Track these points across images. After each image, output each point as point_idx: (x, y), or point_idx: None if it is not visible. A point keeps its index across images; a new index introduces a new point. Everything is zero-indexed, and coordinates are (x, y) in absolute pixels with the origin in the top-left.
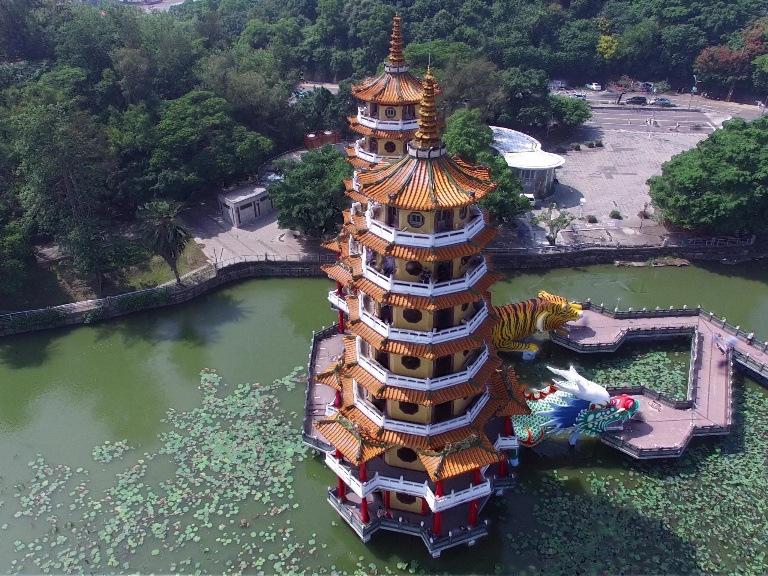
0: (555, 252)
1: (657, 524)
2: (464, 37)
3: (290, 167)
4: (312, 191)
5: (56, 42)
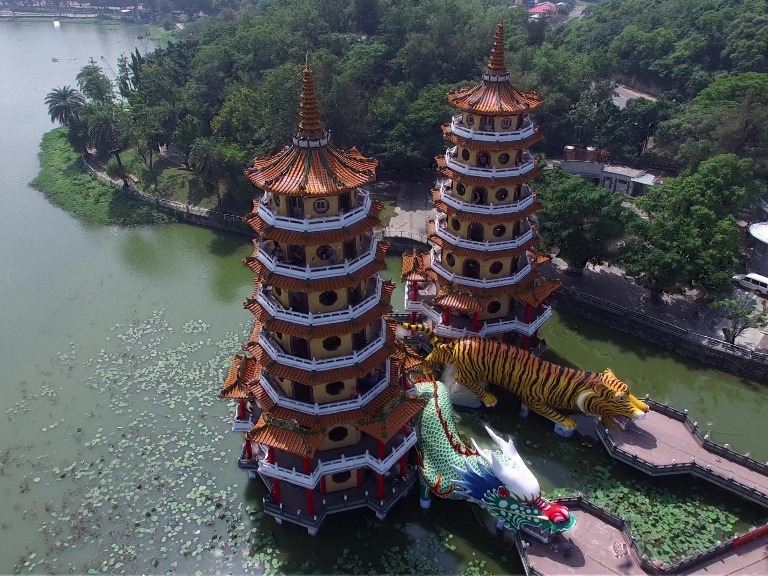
0: (726, 350)
1: None
2: None
3: None
4: None
5: (381, 21)
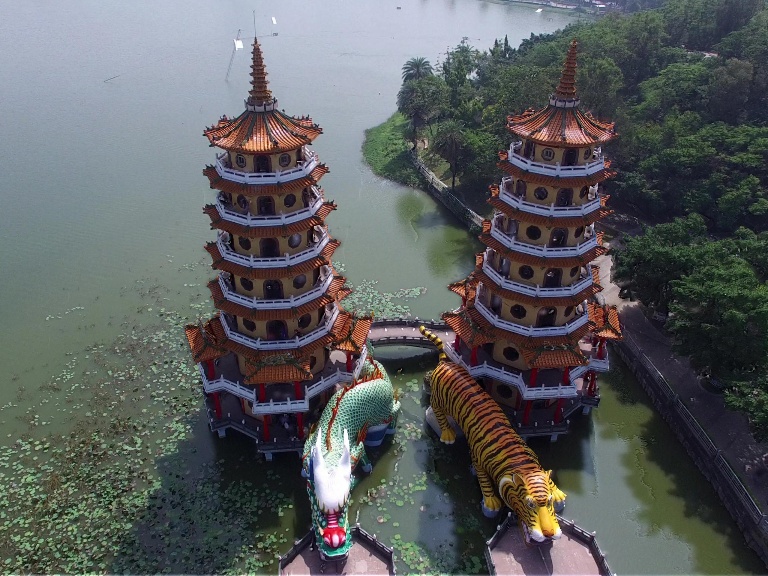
0: None
1: None
2: None
3: None
4: None
5: None
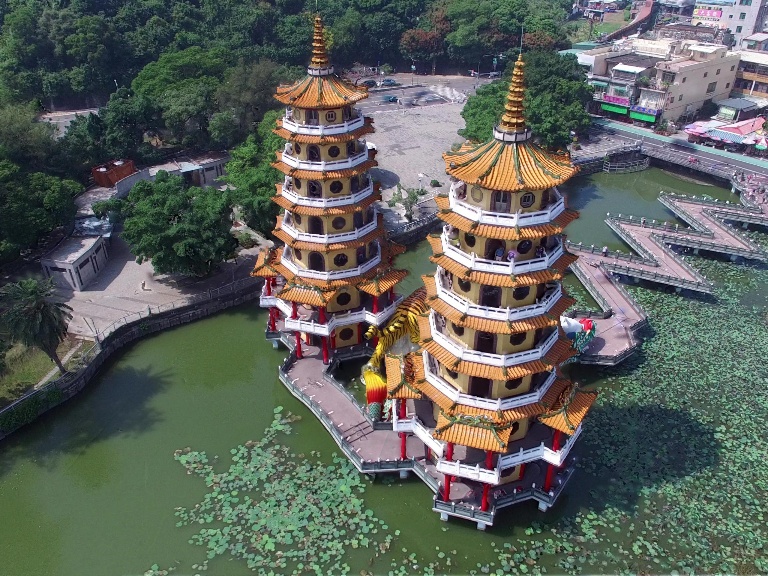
0: (416, 227)
1: (656, 407)
2: (188, 43)
3: (116, 207)
4: (186, 224)
5: None
